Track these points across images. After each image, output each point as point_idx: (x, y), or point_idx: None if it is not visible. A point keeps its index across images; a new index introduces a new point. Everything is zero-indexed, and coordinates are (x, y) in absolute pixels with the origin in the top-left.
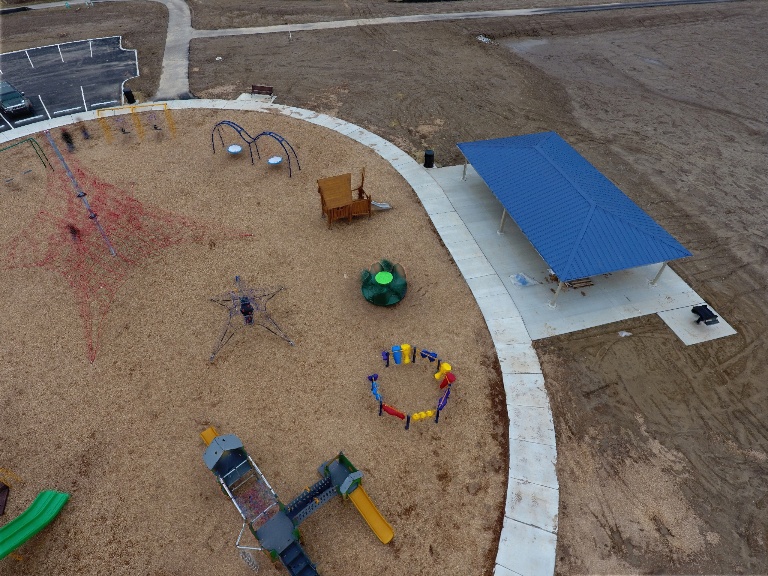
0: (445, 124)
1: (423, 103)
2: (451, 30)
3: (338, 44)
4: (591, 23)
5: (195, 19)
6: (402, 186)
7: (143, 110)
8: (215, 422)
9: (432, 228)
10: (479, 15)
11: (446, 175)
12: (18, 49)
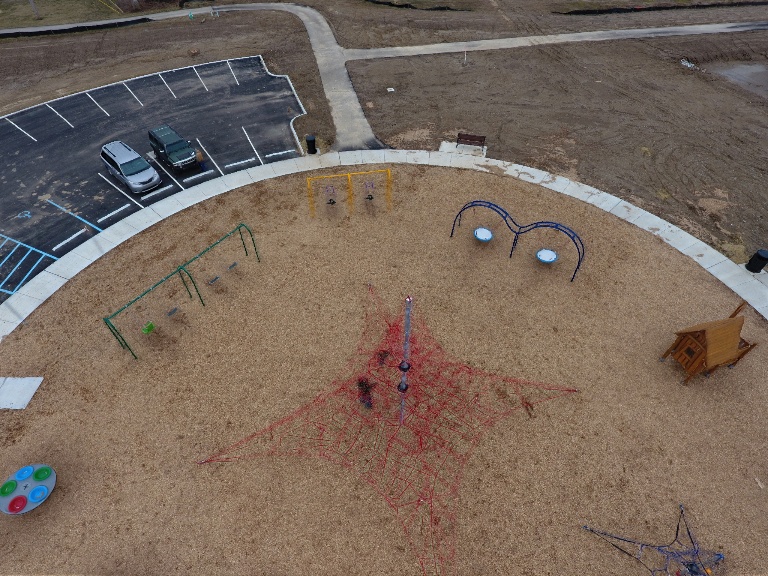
0: (731, 197)
1: (682, 163)
2: (647, 52)
3: (524, 71)
4: None
5: (338, 34)
6: (738, 304)
7: (331, 164)
8: None
9: None
10: (668, 32)
11: None
12: (150, 72)
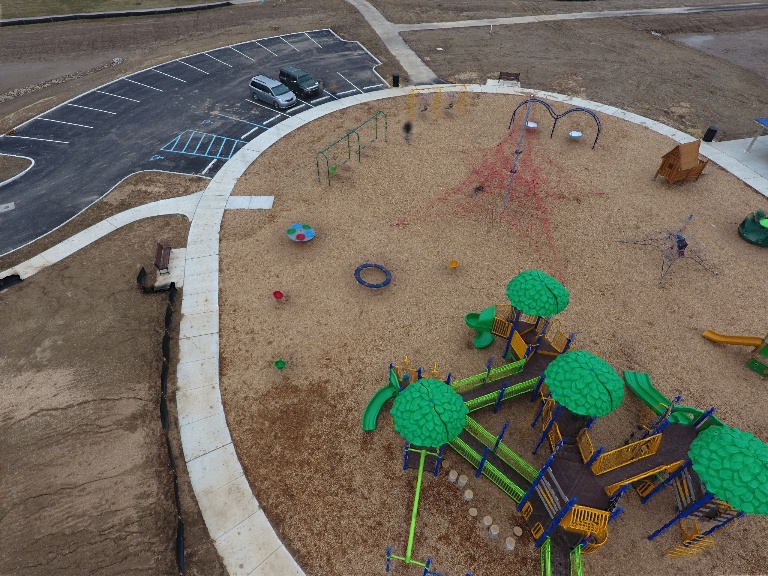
0: (692, 106)
1: (658, 89)
2: (625, 26)
3: (536, 37)
4: (746, 21)
5: (386, 14)
6: None
7: None
8: (703, 328)
9: (753, 190)
10: (640, 13)
11: (729, 148)
12: (248, 40)
